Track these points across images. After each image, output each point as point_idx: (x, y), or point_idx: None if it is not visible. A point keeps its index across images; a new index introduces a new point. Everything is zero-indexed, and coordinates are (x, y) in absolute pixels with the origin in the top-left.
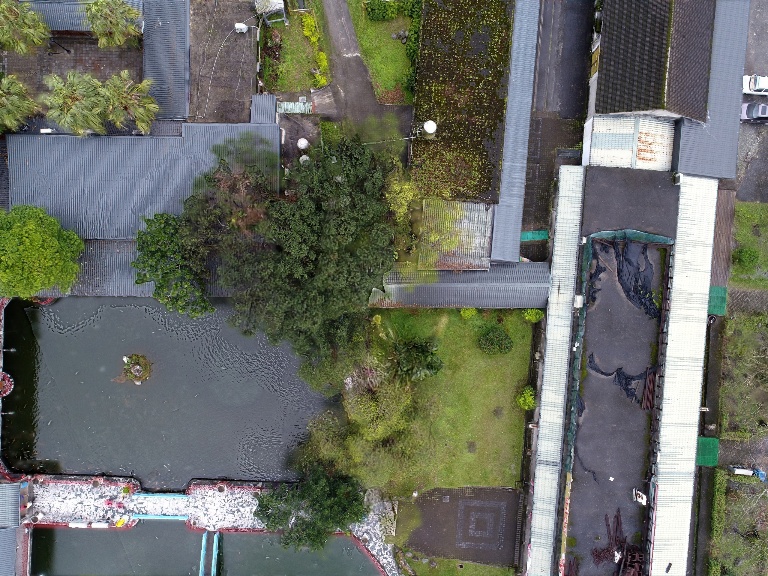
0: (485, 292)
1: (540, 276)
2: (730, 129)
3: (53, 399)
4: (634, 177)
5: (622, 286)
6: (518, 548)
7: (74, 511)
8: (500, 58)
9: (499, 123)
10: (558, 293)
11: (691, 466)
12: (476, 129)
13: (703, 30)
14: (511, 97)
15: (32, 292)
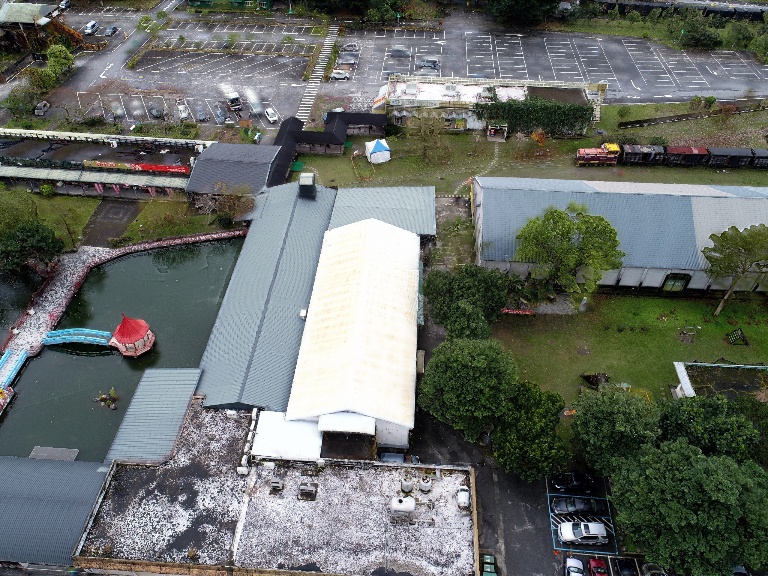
0: None
1: None
2: None
3: None
4: None
5: None
6: (138, 200)
7: None
8: None
9: None
10: None
11: None
12: None
13: None
14: None
15: None
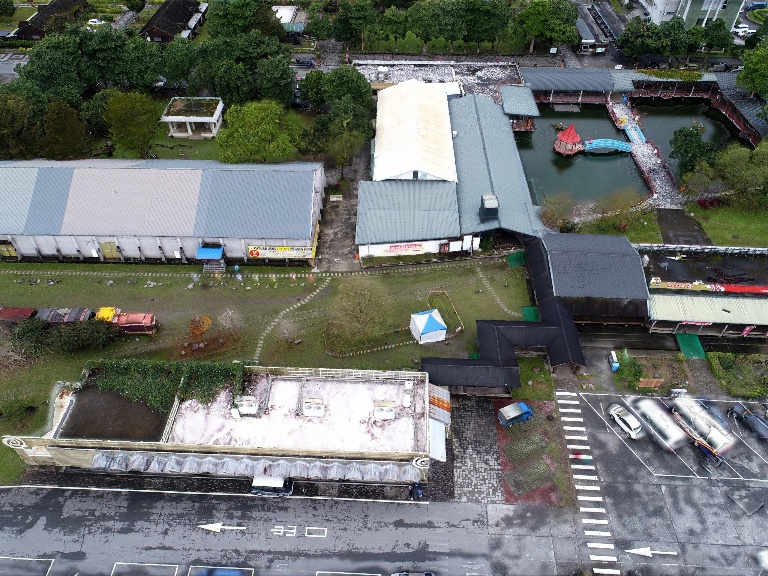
0: None
1: None
2: None
3: (664, 111)
4: None
5: None
6: None
7: (617, 113)
8: None
9: None
10: None
11: None
12: None
13: None
14: None
15: (752, 67)
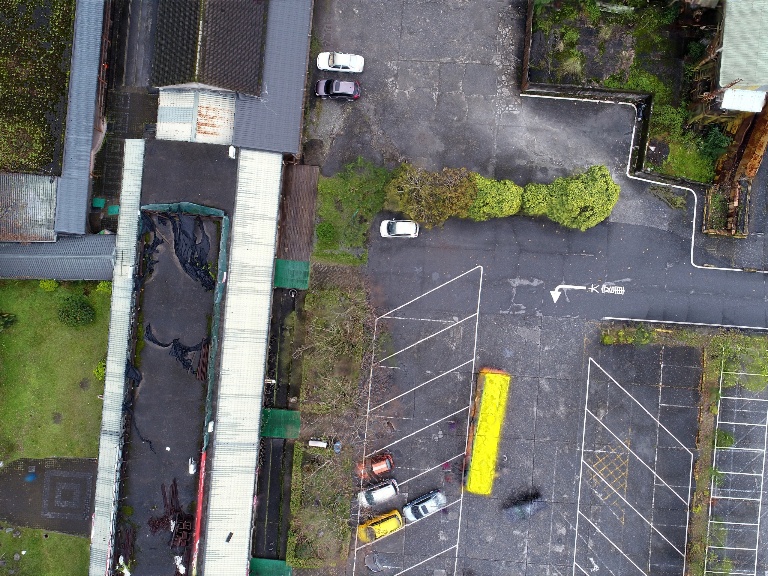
0: (50, 263)
1: (104, 248)
2: (291, 104)
3: None
4: (191, 150)
5: (179, 258)
6: None
7: None
8: (62, 32)
9: (61, 96)
10: (121, 265)
11: (254, 437)
12: (38, 102)
13: (252, 5)
14: (75, 71)
15: None
